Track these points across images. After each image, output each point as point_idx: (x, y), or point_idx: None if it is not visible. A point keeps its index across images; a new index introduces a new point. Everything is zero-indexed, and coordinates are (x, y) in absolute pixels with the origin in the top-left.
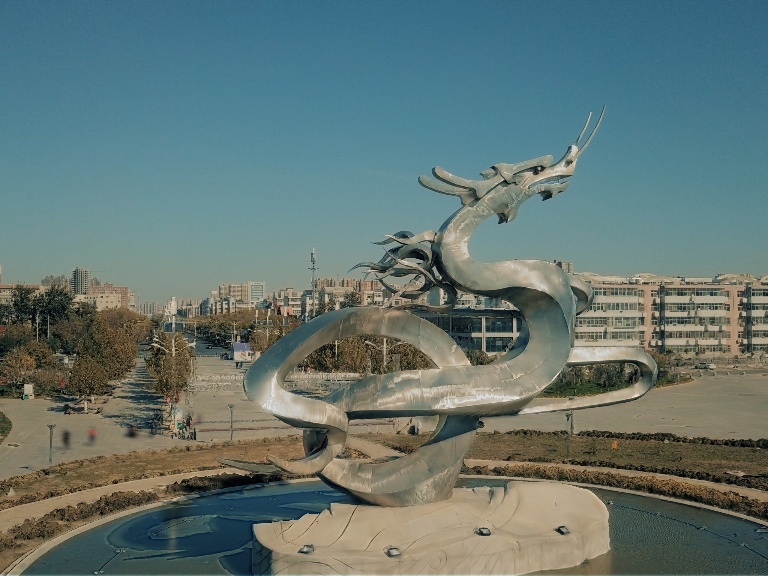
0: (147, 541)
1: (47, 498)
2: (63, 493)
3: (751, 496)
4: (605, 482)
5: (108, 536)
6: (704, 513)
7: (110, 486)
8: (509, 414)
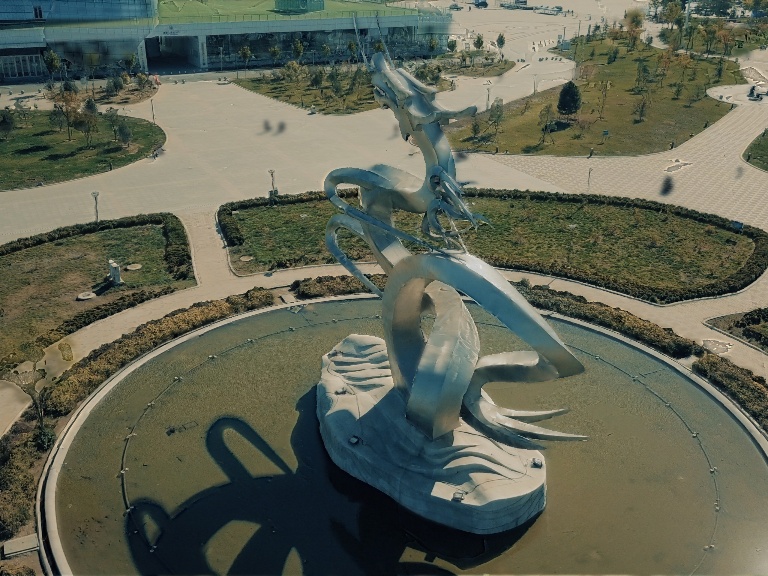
0: None
1: None
2: None
3: (187, 301)
4: (139, 352)
5: None
6: (245, 324)
7: None
8: None
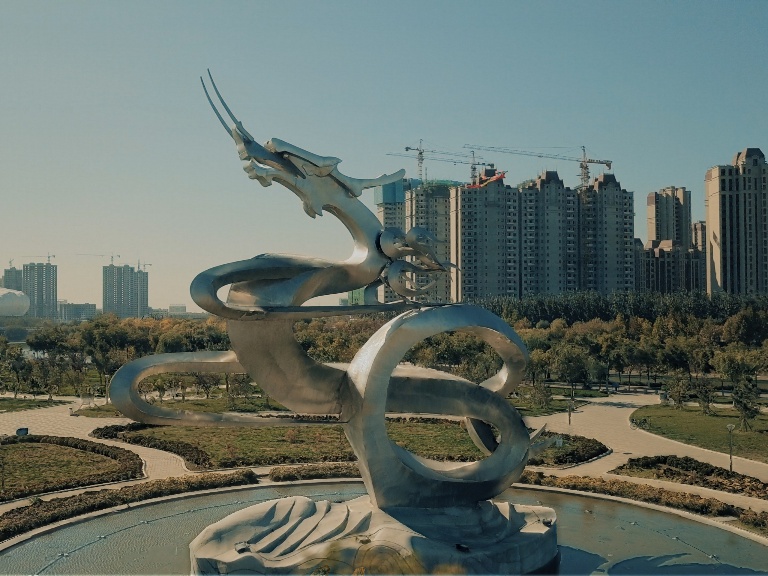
0: (728, 575)
1: None
2: None
3: None
4: None
5: None
6: None
7: None
8: (309, 423)
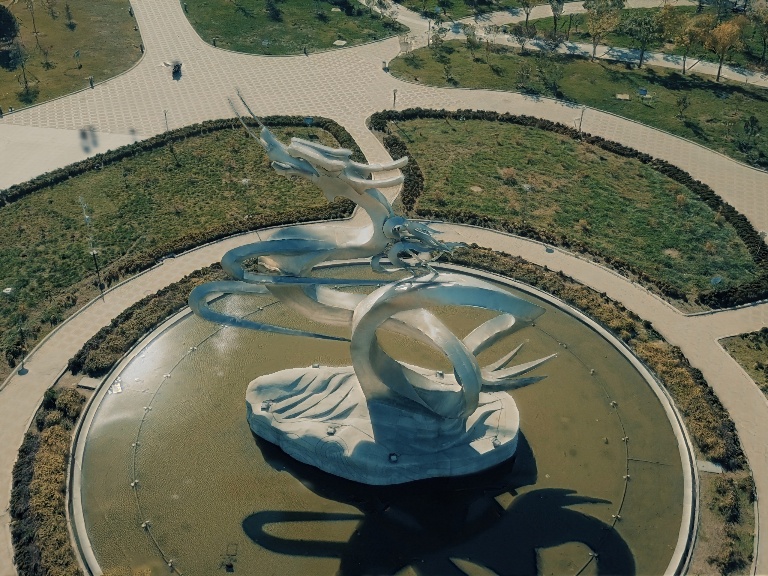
0: (597, 543)
1: None
2: None
3: None
4: None
5: (636, 569)
6: (98, 434)
7: None
8: None
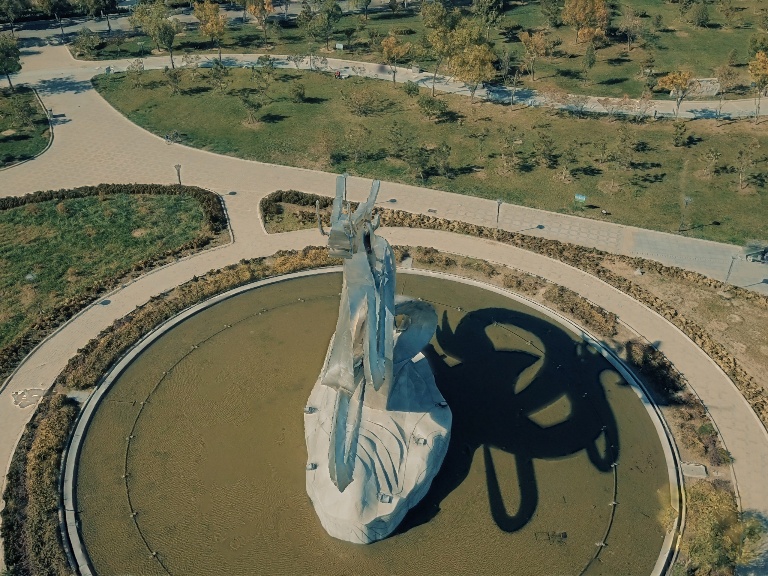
0: (484, 322)
1: (616, 287)
2: (631, 293)
3: None
4: None
5: (502, 308)
6: None
7: (660, 317)
8: None
